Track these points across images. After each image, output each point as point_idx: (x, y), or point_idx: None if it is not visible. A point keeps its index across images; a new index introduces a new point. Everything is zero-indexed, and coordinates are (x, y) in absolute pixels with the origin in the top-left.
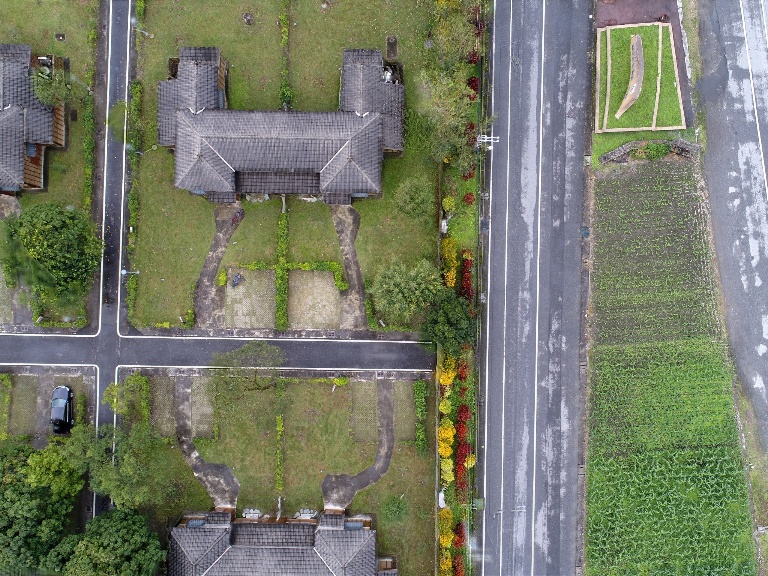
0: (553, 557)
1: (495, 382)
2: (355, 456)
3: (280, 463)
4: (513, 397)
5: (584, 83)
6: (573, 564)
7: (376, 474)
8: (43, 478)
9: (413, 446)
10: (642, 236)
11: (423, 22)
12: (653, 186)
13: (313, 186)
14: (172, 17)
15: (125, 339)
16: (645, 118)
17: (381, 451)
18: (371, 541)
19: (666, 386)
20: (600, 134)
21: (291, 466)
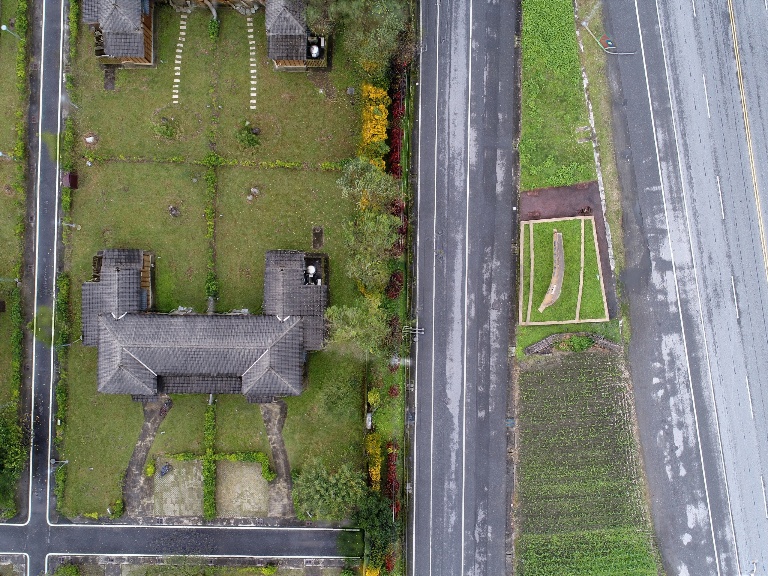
0: None
1: (422, 571)
2: None
3: None
4: None
5: (508, 275)
6: None
7: None
8: None
9: None
10: (567, 426)
11: (348, 213)
12: (577, 377)
13: (236, 387)
14: (99, 209)
15: (55, 528)
16: (568, 311)
17: None
18: None
19: (592, 575)
20: (524, 326)
21: None
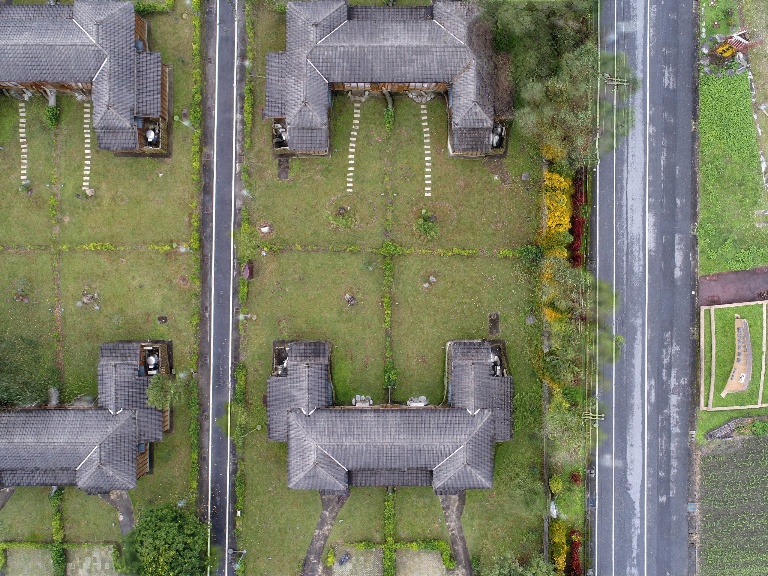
0: None
1: None
2: None
3: None
4: None
5: (688, 359)
6: None
7: None
8: None
9: None
10: (748, 510)
11: (525, 299)
12: (759, 461)
13: (424, 479)
14: (274, 298)
15: None
16: (751, 396)
17: None
18: None
19: None
20: (705, 411)
21: None
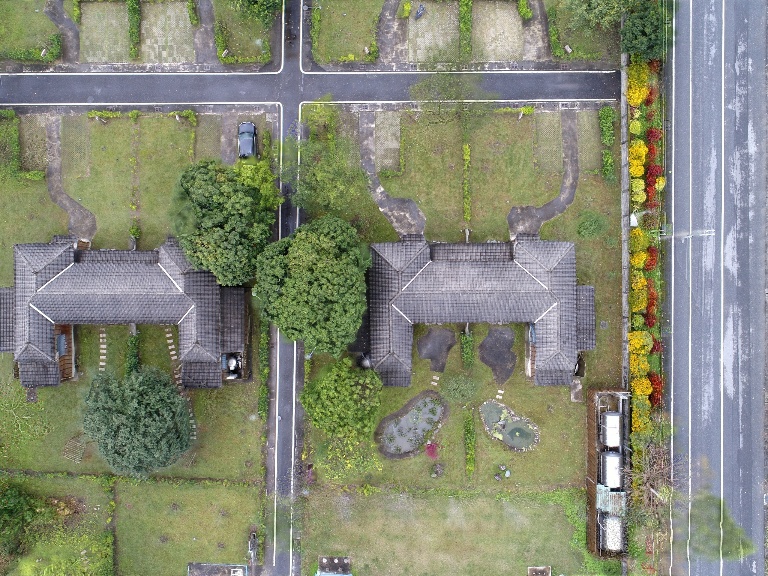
0: (743, 280)
1: (682, 106)
2: (540, 187)
3: (468, 193)
4: (700, 121)
5: None
6: (763, 287)
7: (561, 205)
8: (255, 177)
9: (598, 176)
10: None
11: None
12: None
13: None
14: None
15: (308, 75)
16: None
17: (566, 182)
18: (572, 251)
19: None
20: None
21: (477, 198)
